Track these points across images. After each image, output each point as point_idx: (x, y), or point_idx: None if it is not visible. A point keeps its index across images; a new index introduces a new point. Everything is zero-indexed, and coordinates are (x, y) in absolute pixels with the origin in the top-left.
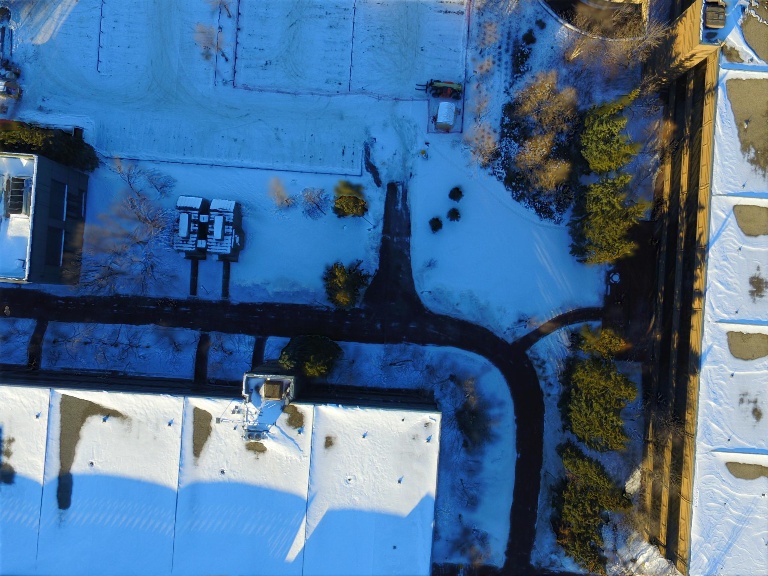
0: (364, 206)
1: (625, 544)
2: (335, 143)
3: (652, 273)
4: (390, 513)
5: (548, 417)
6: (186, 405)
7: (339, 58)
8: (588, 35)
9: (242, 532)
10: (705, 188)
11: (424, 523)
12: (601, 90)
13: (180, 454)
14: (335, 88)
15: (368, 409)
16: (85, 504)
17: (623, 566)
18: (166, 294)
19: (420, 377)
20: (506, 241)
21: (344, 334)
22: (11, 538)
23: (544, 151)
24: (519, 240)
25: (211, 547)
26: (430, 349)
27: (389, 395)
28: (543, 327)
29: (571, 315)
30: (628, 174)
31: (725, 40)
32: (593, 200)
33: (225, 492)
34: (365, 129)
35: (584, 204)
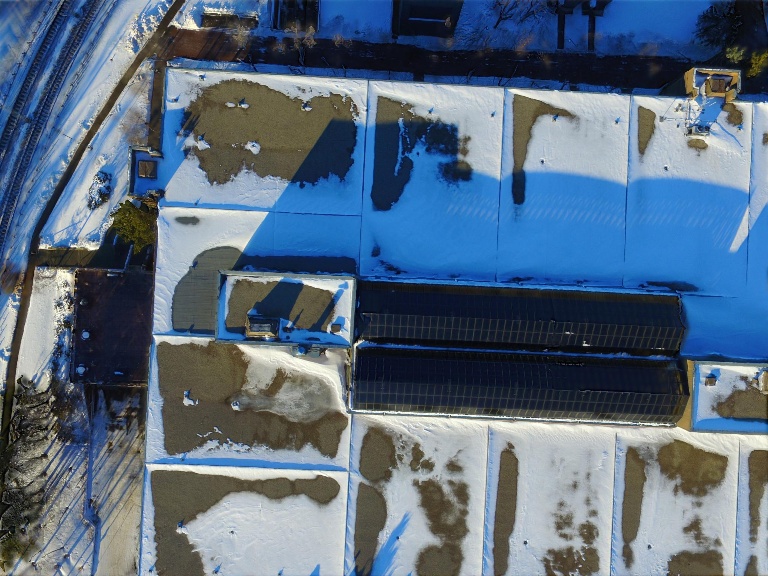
0: None
1: None
2: None
3: None
4: None
5: None
6: (632, 103)
7: None
8: None
9: (687, 225)
10: None
11: None
12: None
13: (628, 150)
14: None
15: None
16: (539, 199)
17: None
18: (536, 47)
19: None
20: None
21: None
22: (471, 231)
23: None
24: None
25: (659, 239)
26: None
27: None
28: None
29: None
30: None
31: None
32: None
33: (669, 187)
34: None
35: None
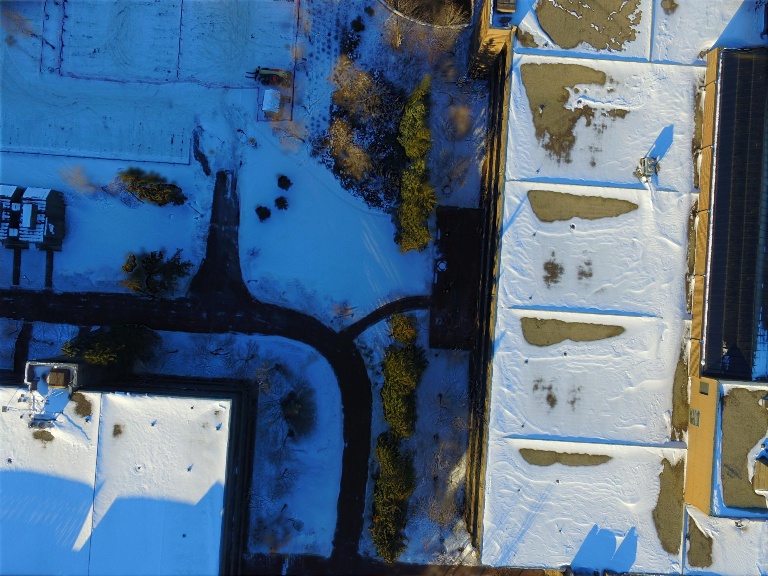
0: (191, 195)
1: (451, 533)
2: (164, 131)
3: (478, 261)
4: (180, 501)
5: (375, 406)
6: None
7: (168, 46)
8: (417, 22)
9: (29, 521)
10: (502, 174)
11: (214, 511)
12: (430, 77)
13: None
14: (164, 76)
15: (157, 397)
16: None
17: (450, 555)
18: None
19: (245, 366)
20: (334, 229)
21: (169, 323)
22: None
23: (372, 139)
24: (348, 228)
25: None
26: (256, 338)
27: (204, 384)
28: (371, 316)
29: (399, 304)
30: (432, 160)
31: (520, 24)
32: (405, 187)
33: (12, 481)
34: (194, 117)
35: (400, 191)
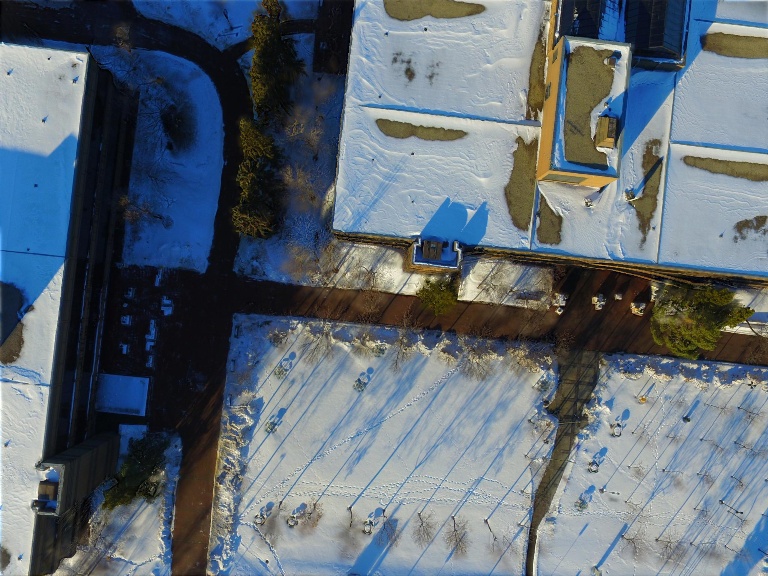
0: None
1: (326, 252)
2: None
3: None
4: (33, 152)
5: None
6: None
7: None
8: None
9: None
10: None
11: (67, 163)
12: None
13: None
14: None
15: (13, 46)
16: None
17: (324, 275)
18: None
19: (126, 77)
20: None
21: (52, 32)
22: None
23: None
24: None
25: None
26: (140, 52)
27: None
28: None
29: (284, 26)
30: None
31: None
32: None
33: None
34: None
35: None
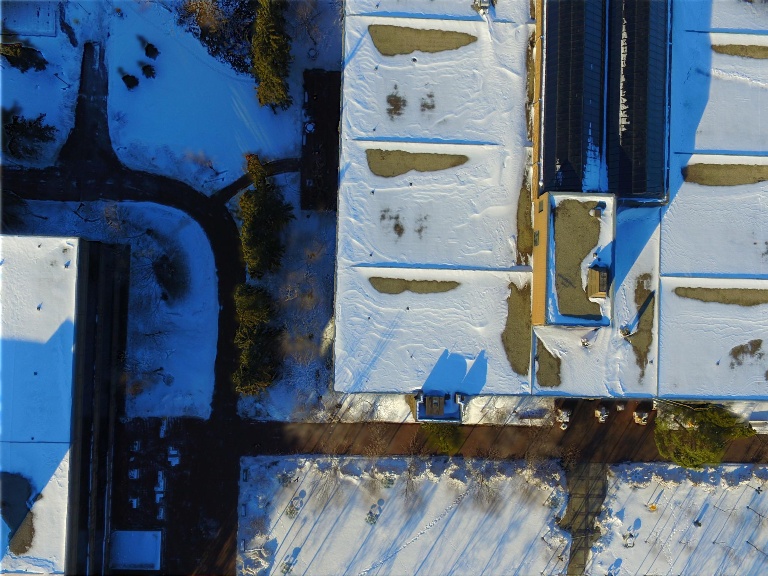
0: (57, 65)
1: (328, 389)
2: (30, 5)
3: None
4: (30, 340)
5: None
6: None
7: None
8: None
9: None
10: None
11: (65, 348)
12: None
13: None
14: None
15: (3, 236)
16: None
17: (328, 412)
18: None
19: (116, 232)
20: (203, 96)
21: (39, 193)
22: None
23: (237, 5)
24: (216, 95)
25: None
26: (127, 205)
27: None
28: (241, 179)
29: (269, 167)
30: (279, 5)
31: None
32: None
33: None
34: None
35: None
